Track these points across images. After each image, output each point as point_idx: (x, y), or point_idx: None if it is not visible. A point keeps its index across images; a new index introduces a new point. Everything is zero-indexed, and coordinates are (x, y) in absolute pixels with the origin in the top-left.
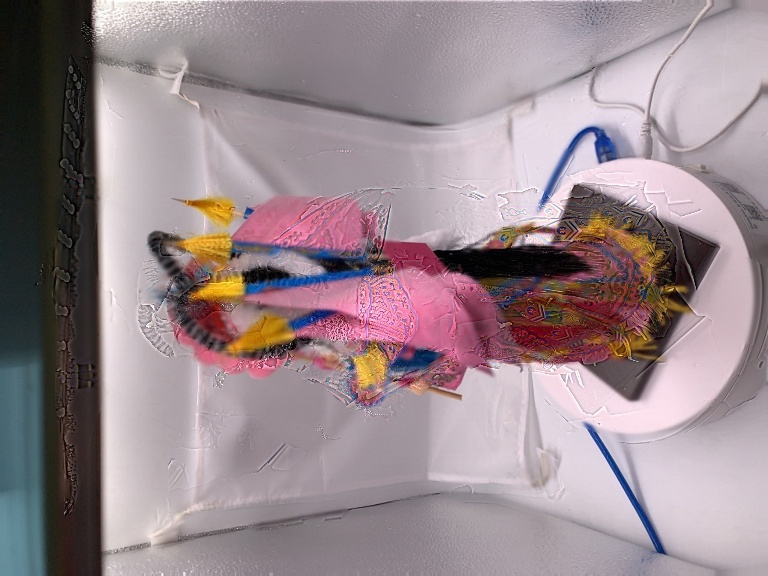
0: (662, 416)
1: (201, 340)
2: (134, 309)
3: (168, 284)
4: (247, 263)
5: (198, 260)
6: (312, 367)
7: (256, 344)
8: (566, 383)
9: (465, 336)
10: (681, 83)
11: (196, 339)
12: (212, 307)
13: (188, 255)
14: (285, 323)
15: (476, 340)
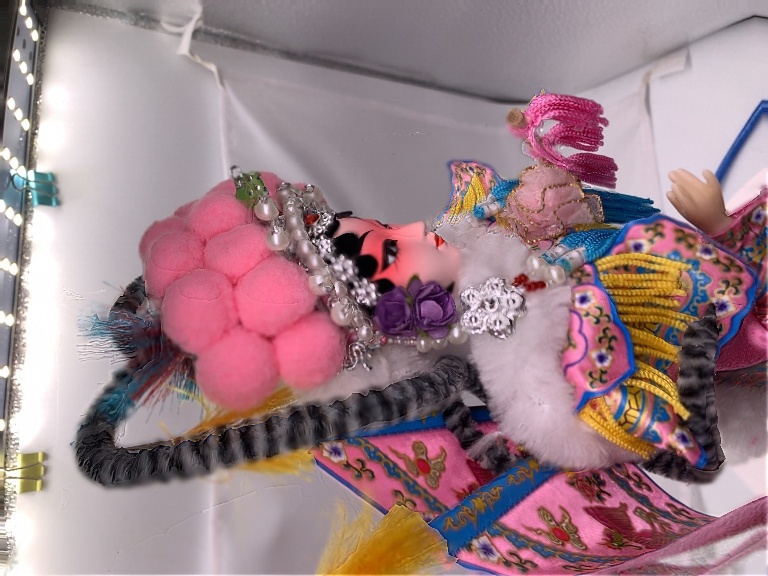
0: None
1: None
2: (62, 450)
3: (108, 317)
4: None
5: None
6: (465, 251)
7: None
8: None
9: None
10: None
11: None
12: None
13: None
14: None
15: None
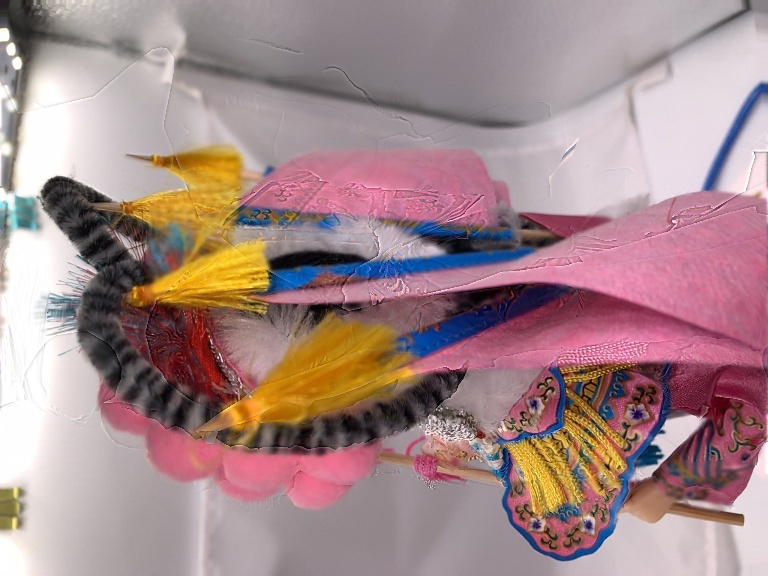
0: None
1: (144, 449)
2: None
3: None
4: (311, 298)
5: (183, 244)
6: None
7: (262, 510)
8: None
9: (662, 501)
10: None
11: (132, 447)
12: (193, 358)
13: (124, 390)
14: (342, 485)
15: (674, 506)
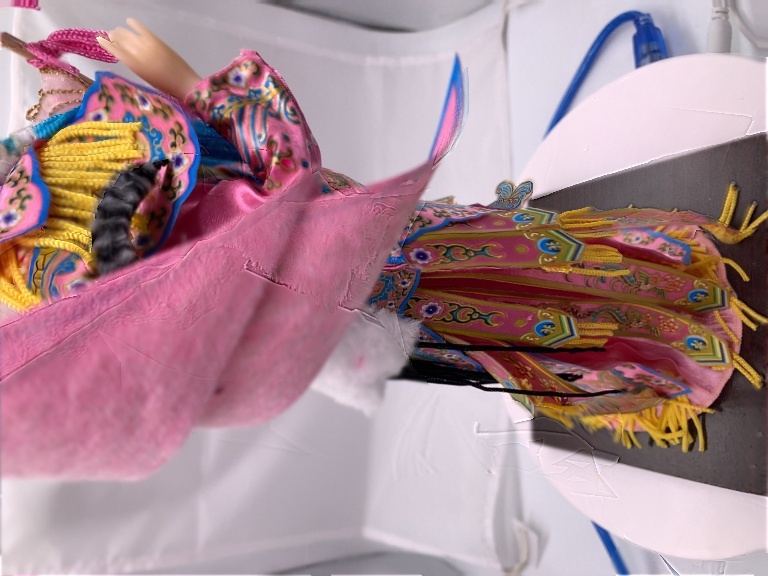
0: (663, 91)
1: None
2: None
3: None
4: None
5: None
6: None
7: None
8: (767, 210)
9: None
10: (648, 570)
11: None
12: None
13: None
14: None
15: None
